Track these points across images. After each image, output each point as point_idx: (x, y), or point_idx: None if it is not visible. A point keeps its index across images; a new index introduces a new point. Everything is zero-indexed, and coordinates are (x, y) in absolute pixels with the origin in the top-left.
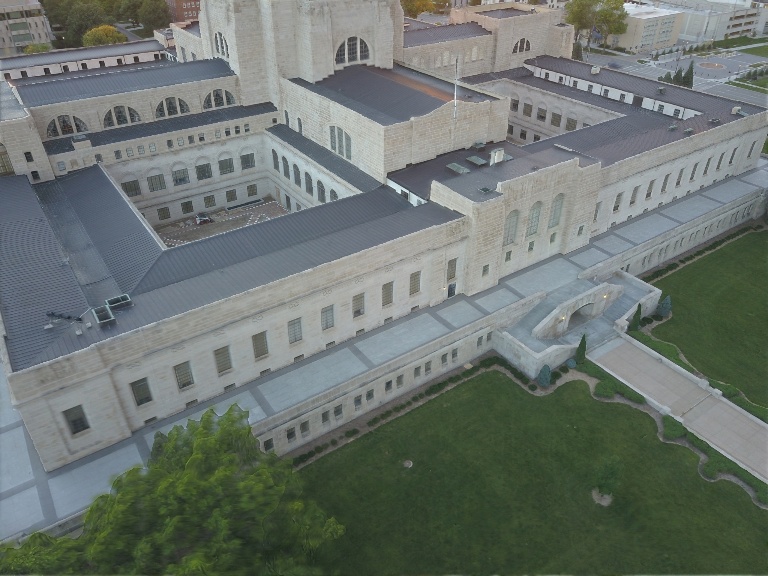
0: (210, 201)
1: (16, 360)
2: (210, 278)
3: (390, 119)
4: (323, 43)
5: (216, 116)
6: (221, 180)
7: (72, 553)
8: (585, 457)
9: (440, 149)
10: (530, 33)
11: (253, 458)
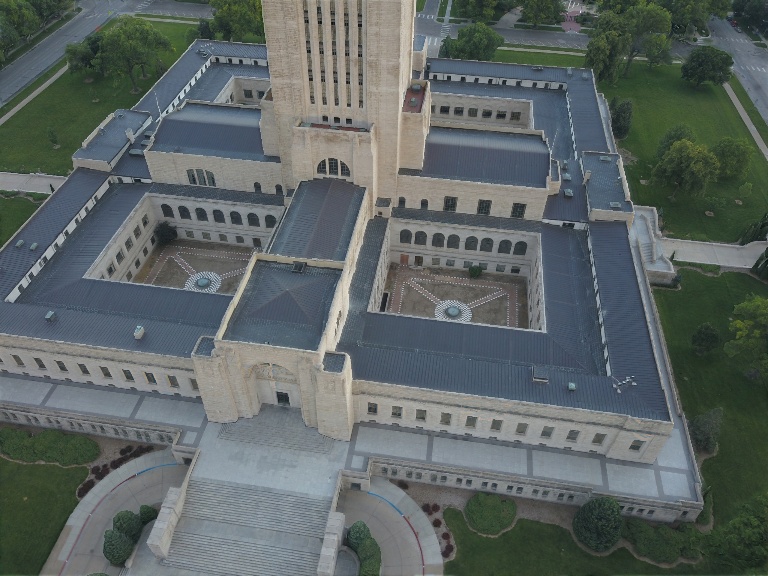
0: None
1: (204, 42)
2: (193, 69)
3: (196, 111)
4: None
5: None
6: None
7: (128, 27)
8: (66, 152)
9: None
10: None
11: (120, 49)
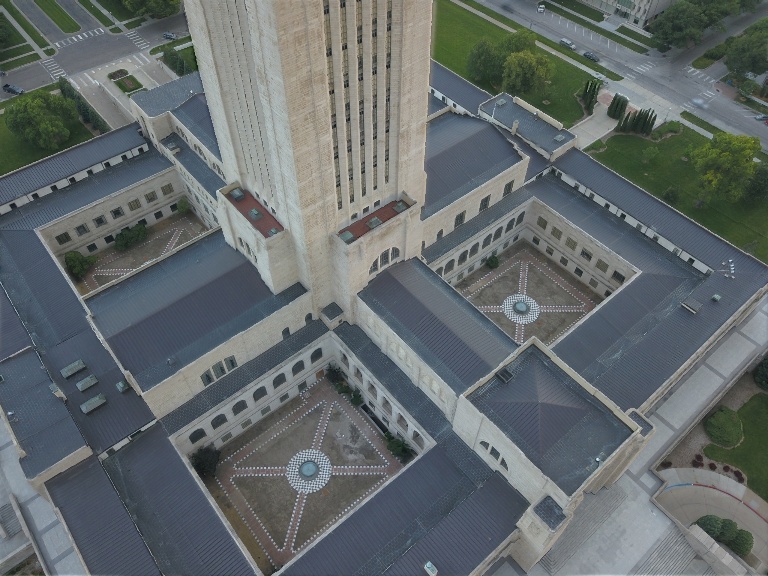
0: None
1: None
2: None
3: (113, 303)
4: None
5: None
6: None
7: None
8: None
9: None
10: (509, 458)
11: None
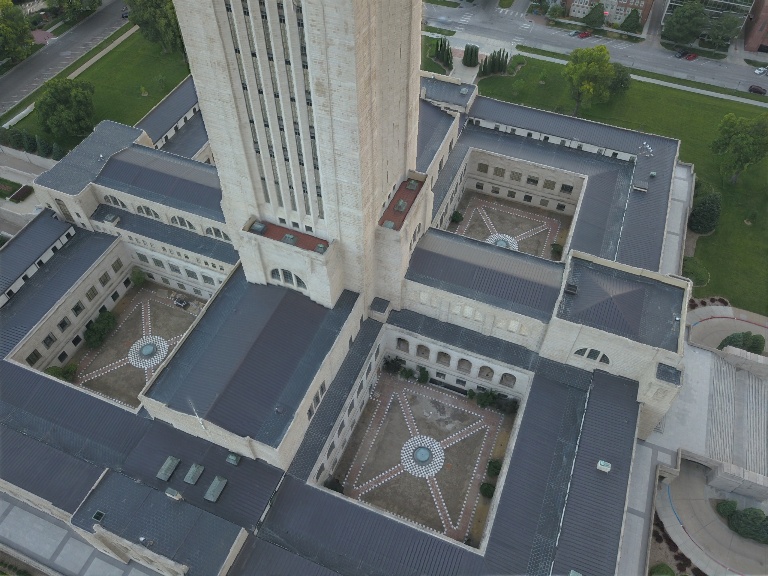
0: (199, 292)
1: None
2: None
3: (177, 384)
4: (252, 262)
5: (209, 245)
6: (205, 285)
7: None
8: None
9: (200, 435)
10: (611, 351)
11: None
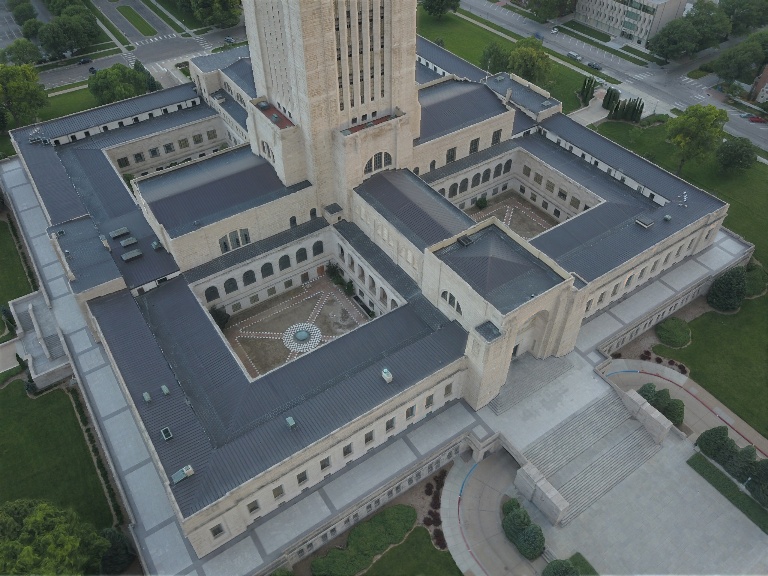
0: None
1: (21, 131)
2: None
3: (157, 185)
4: None
5: None
6: None
7: None
8: None
9: None
10: (461, 298)
11: None
